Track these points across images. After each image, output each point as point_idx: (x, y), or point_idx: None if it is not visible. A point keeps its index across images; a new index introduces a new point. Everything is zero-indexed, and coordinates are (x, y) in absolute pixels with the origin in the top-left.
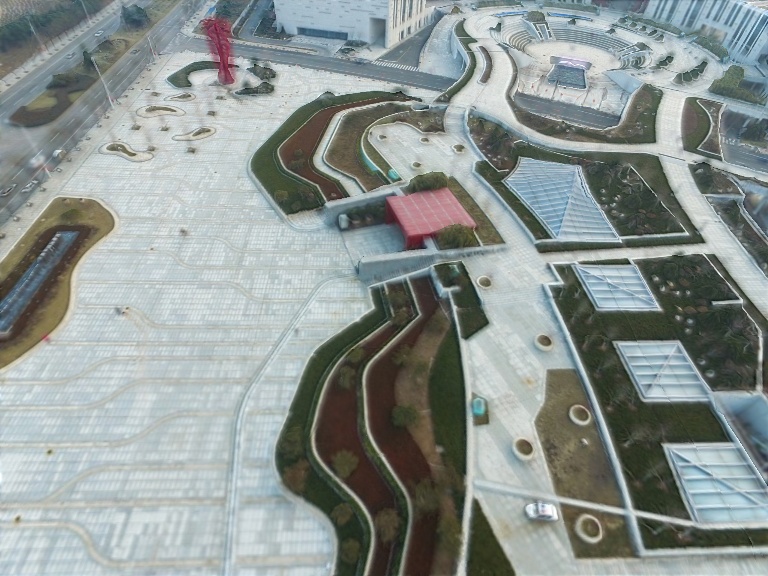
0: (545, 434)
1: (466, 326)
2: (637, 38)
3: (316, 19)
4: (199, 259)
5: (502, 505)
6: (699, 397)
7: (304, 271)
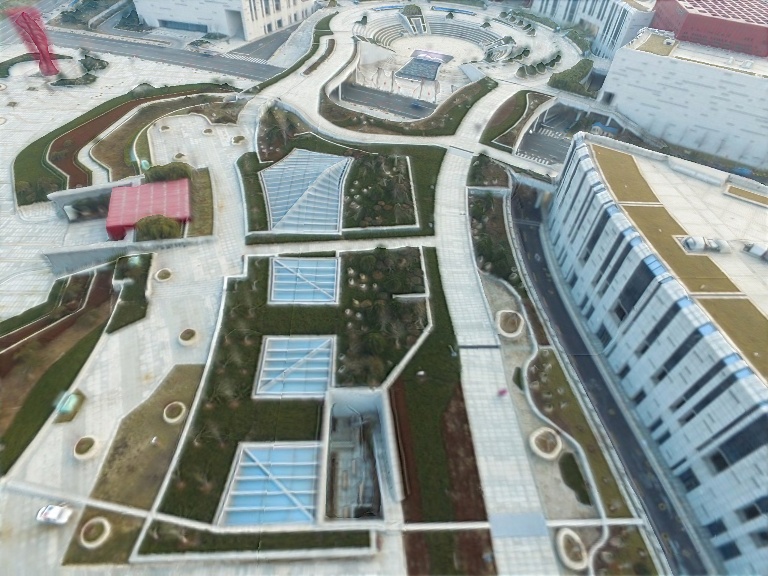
0: (125, 432)
1: (118, 320)
2: (511, 32)
3: (174, 11)
4: None
5: (22, 507)
6: (316, 393)
7: (1, 263)
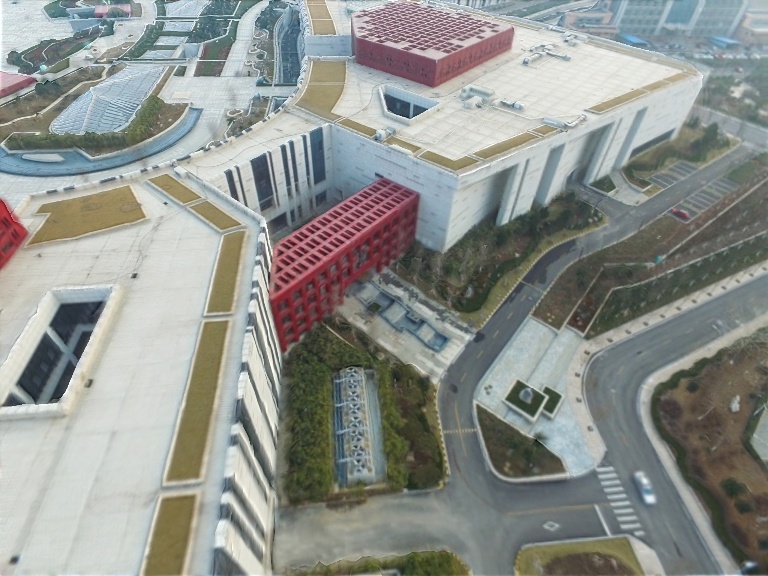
0: None
1: None
2: None
3: None
4: (1, 29)
5: None
6: None
7: None
